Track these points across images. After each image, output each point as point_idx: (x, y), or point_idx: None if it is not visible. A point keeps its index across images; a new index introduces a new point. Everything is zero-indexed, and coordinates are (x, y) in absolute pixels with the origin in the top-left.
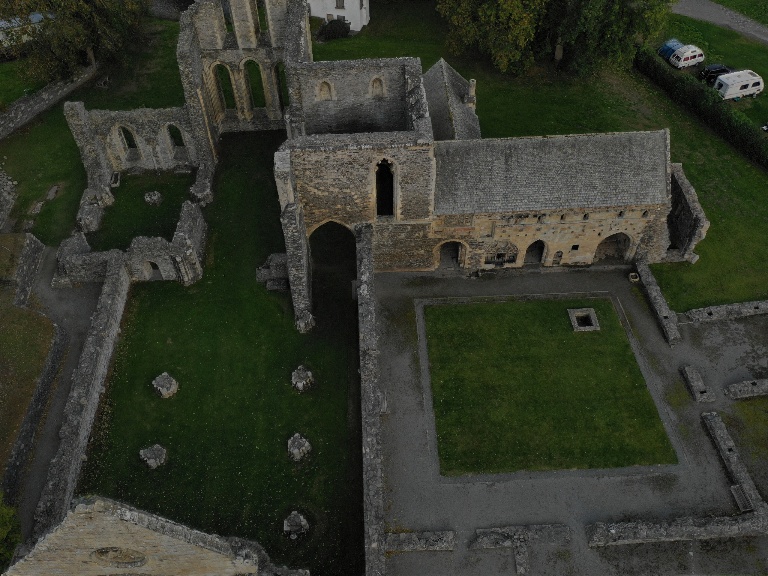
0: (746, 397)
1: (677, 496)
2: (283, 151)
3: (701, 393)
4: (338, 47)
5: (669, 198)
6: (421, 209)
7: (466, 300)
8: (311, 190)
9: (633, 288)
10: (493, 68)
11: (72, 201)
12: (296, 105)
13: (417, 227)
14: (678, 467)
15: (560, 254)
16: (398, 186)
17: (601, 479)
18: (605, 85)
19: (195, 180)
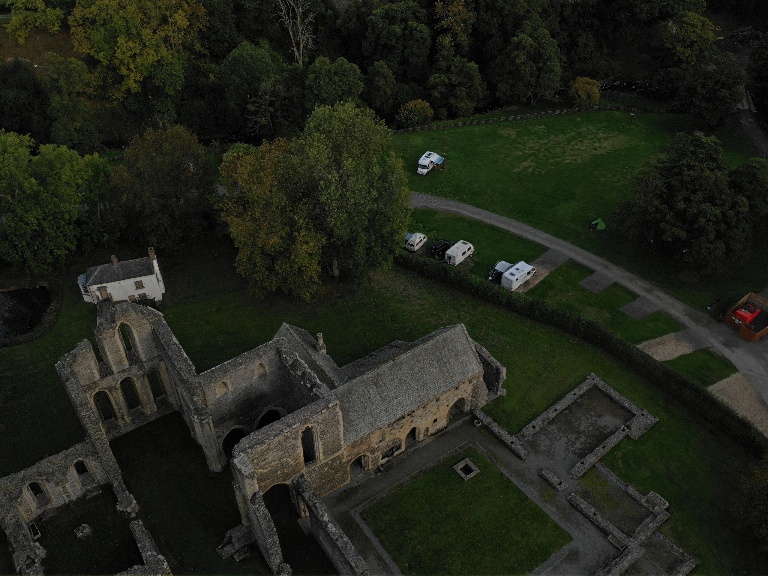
0: (583, 474)
1: (585, 561)
2: (239, 456)
3: (559, 485)
4: None
5: (481, 366)
6: (336, 446)
7: (385, 494)
8: (258, 471)
9: (481, 431)
10: (292, 298)
11: (2, 572)
12: (202, 406)
13: (334, 459)
14: (575, 542)
15: (427, 429)
16: (319, 439)
17: (540, 575)
18: (377, 283)
19: (110, 497)
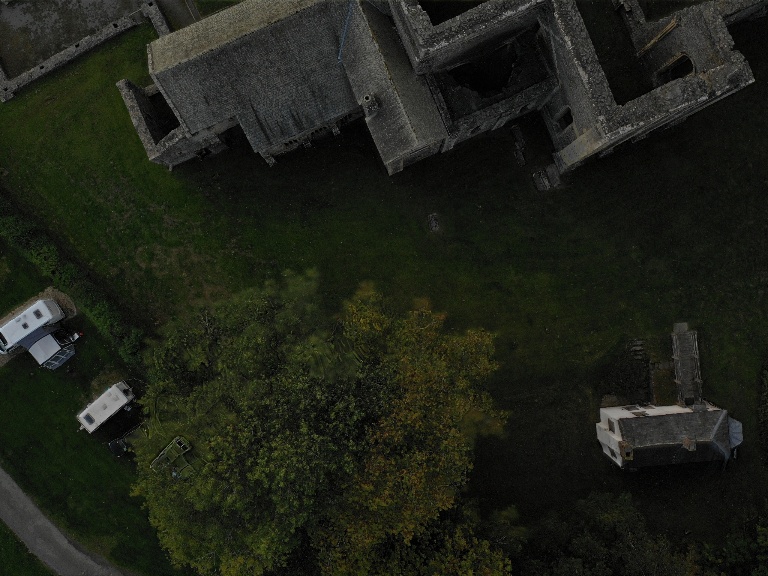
0: None
1: None
2: None
3: None
4: (606, 337)
5: None
6: None
7: None
8: None
9: None
10: None
11: None
12: None
13: None
14: None
15: None
16: None
17: None
18: None
19: None
